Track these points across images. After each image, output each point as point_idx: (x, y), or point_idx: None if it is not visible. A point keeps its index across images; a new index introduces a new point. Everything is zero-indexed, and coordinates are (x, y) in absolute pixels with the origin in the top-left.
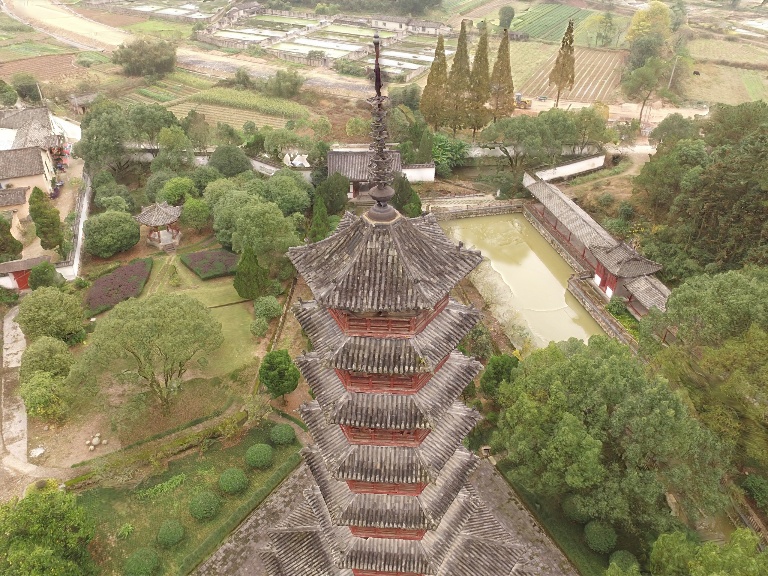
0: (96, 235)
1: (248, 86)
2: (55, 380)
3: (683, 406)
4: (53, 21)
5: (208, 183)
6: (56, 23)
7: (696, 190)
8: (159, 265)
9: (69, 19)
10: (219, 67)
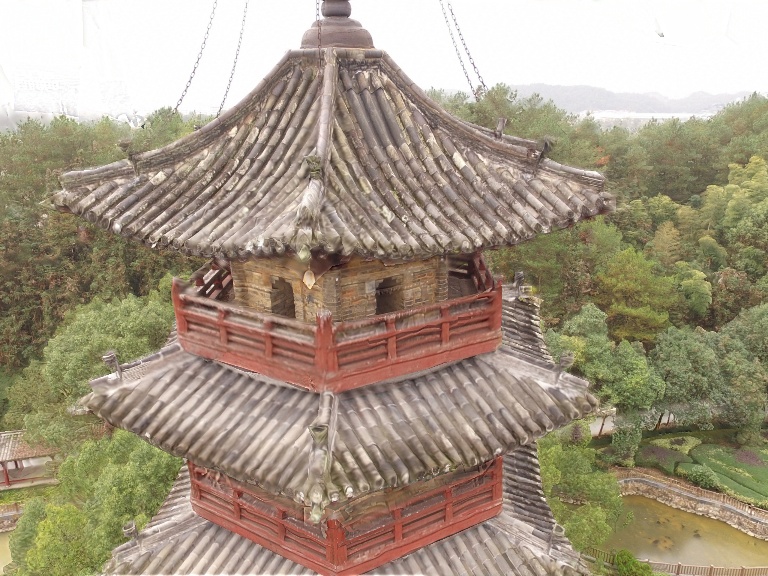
0: None
1: None
2: None
3: None
4: None
5: None
6: None
7: None
8: None
9: None
10: None
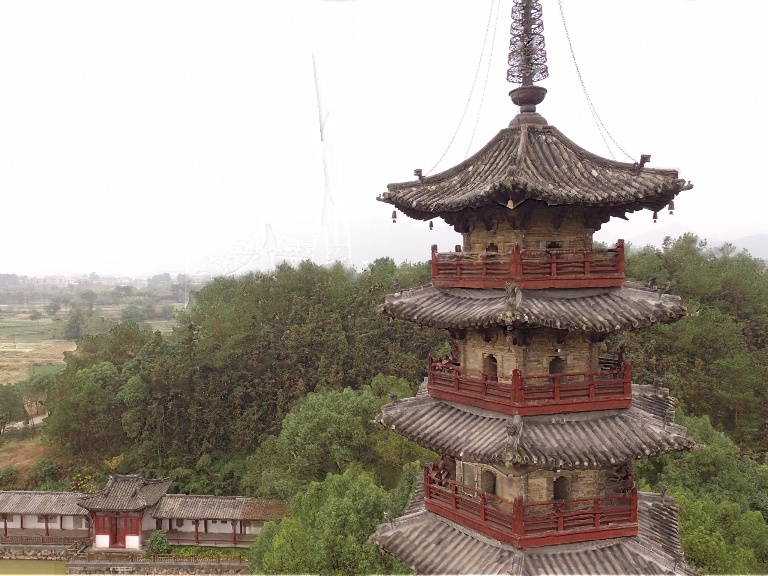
0: None
1: None
2: None
3: None
4: None
5: None
6: None
7: (146, 399)
8: None
9: None
10: None
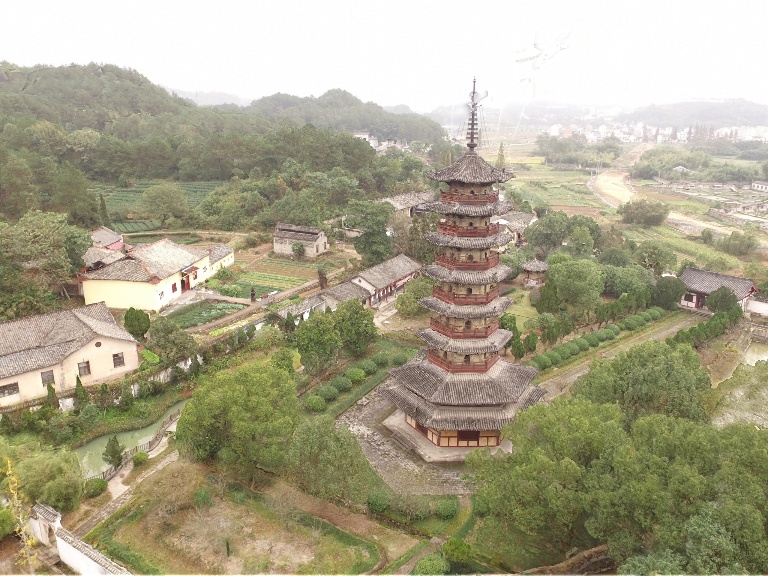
0: None
1: (708, 242)
2: (415, 299)
3: (682, 379)
4: (611, 191)
5: None
6: (611, 192)
7: None
8: (517, 293)
9: (624, 192)
10: (700, 229)
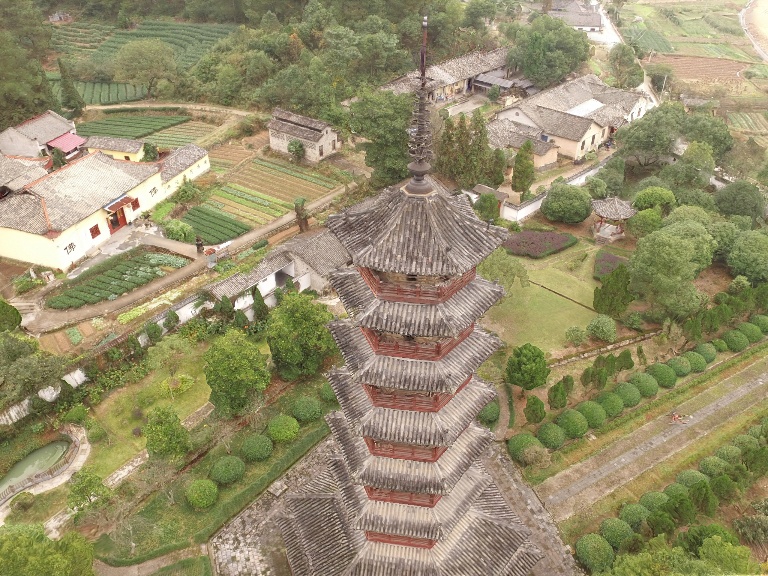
0: (552, 198)
1: None
2: None
3: None
4: None
5: (682, 205)
6: None
7: None
8: (579, 248)
9: None
10: None
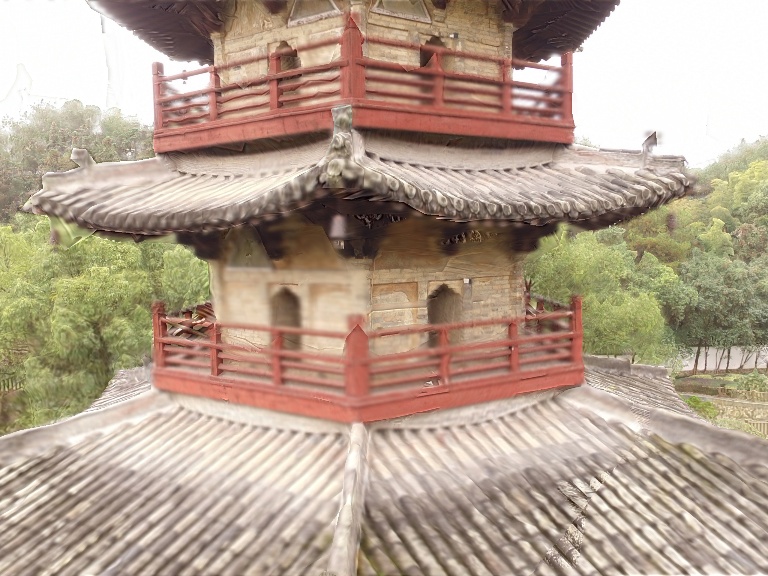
0: None
1: None
2: None
3: None
4: None
5: None
6: None
7: None
8: None
9: None
10: None
